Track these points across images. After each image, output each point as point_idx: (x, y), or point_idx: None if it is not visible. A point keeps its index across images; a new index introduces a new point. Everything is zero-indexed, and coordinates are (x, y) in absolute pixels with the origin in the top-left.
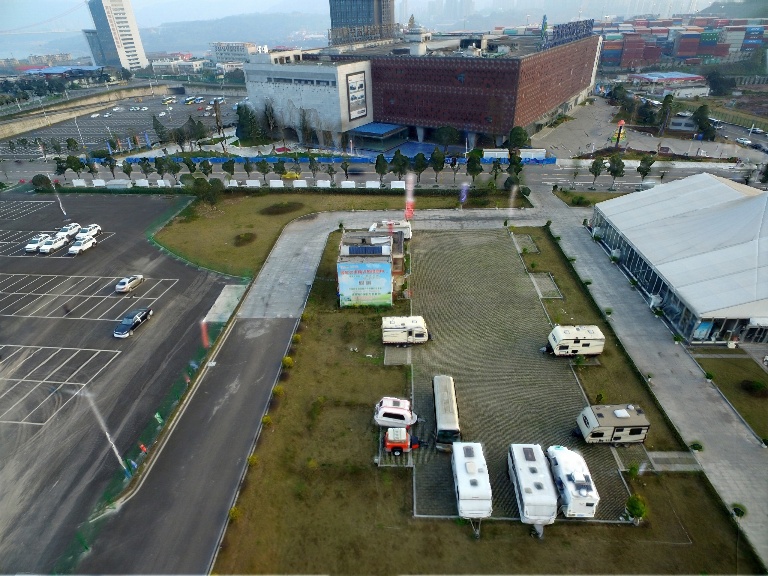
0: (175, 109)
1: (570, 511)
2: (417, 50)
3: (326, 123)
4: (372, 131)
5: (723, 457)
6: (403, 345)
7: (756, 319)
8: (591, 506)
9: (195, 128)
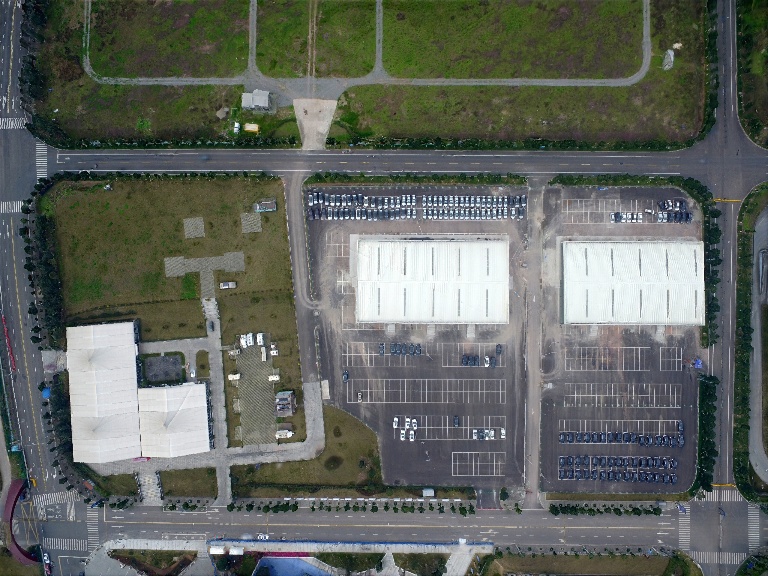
0: None
1: None
2: None
3: (334, 573)
4: None
5: (217, 350)
6: None
7: None
8: None
9: (419, 569)
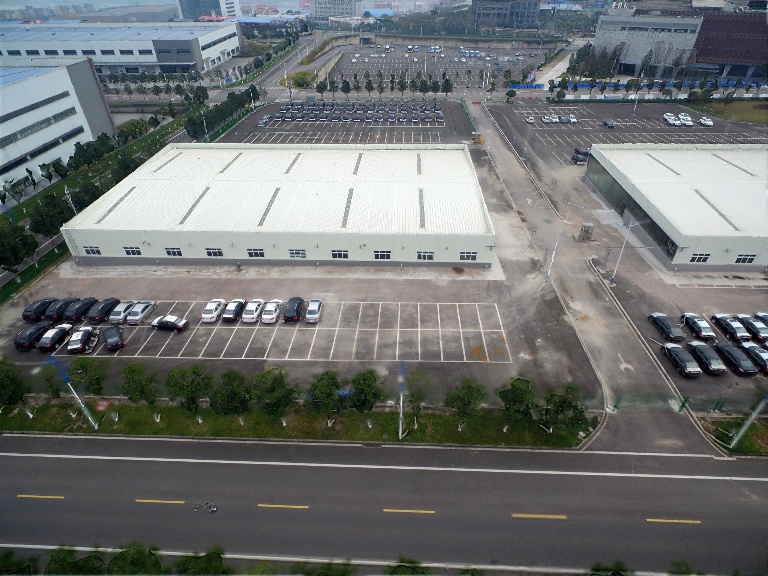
0: (410, 56)
1: None
2: (731, 8)
3: None
4: None
5: None
6: None
7: None
8: None
9: (600, 62)
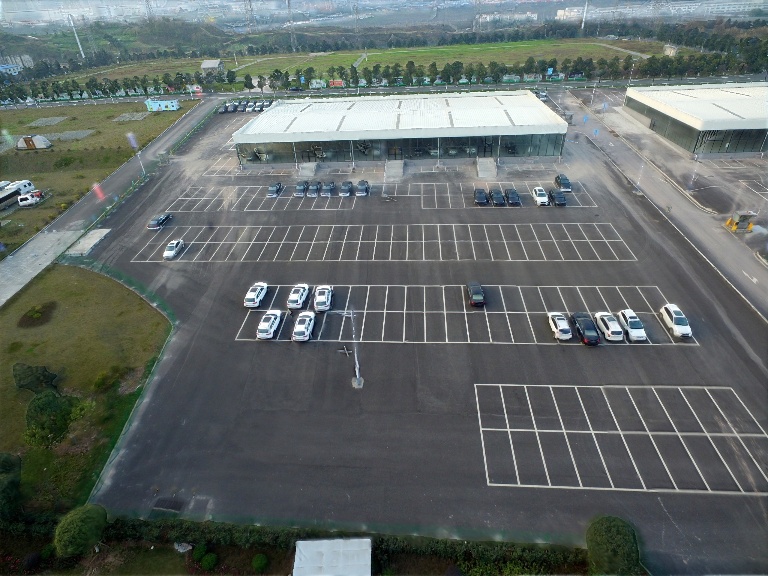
0: None
1: None
2: None
3: None
4: None
5: None
6: None
7: None
8: None
9: None
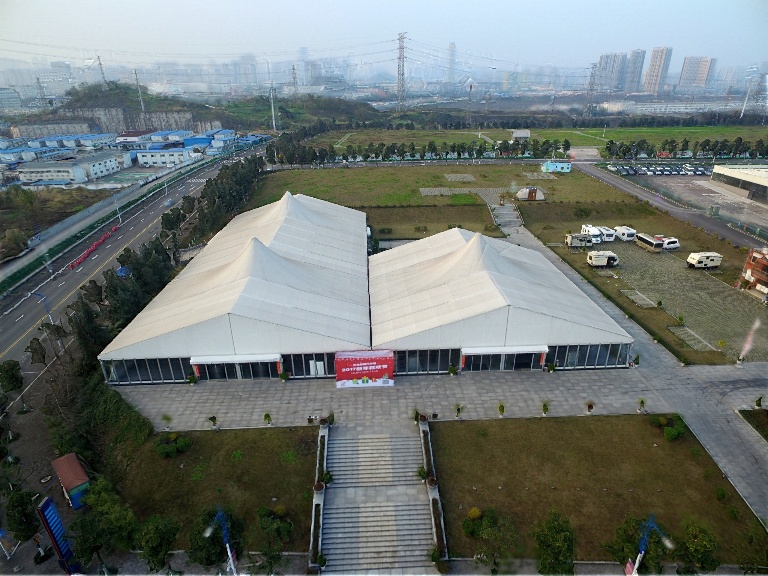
0: None
1: None
2: None
3: None
4: None
5: (535, 246)
6: None
7: None
8: None
9: None
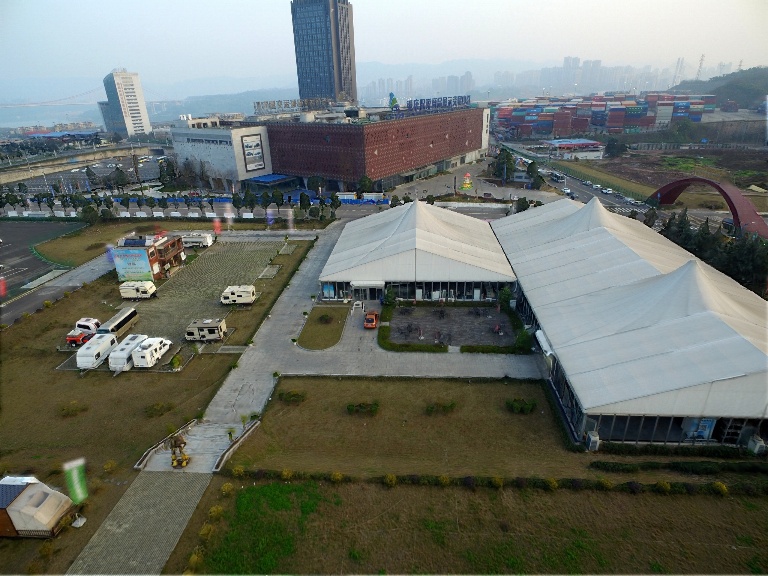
0: (145, 166)
1: (135, 363)
2: (305, 118)
3: (219, 172)
4: (263, 180)
5: (264, 348)
6: (136, 300)
7: (353, 282)
8: (144, 358)
9: (119, 176)
